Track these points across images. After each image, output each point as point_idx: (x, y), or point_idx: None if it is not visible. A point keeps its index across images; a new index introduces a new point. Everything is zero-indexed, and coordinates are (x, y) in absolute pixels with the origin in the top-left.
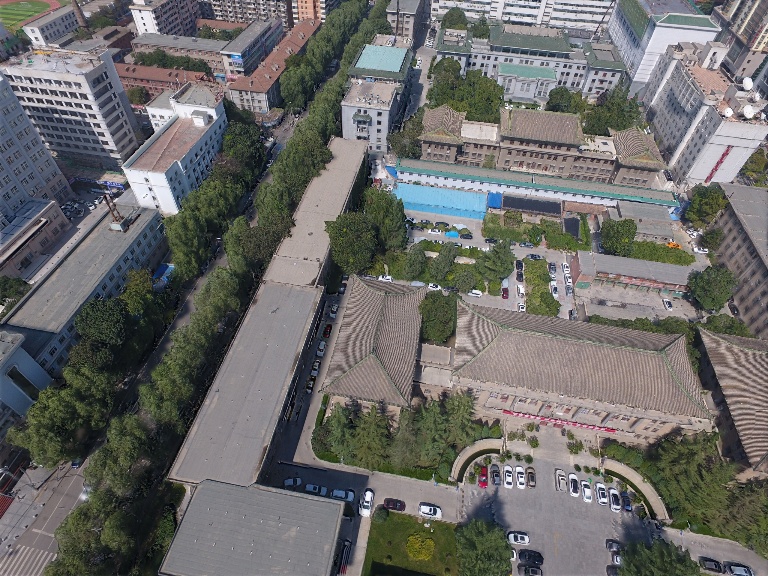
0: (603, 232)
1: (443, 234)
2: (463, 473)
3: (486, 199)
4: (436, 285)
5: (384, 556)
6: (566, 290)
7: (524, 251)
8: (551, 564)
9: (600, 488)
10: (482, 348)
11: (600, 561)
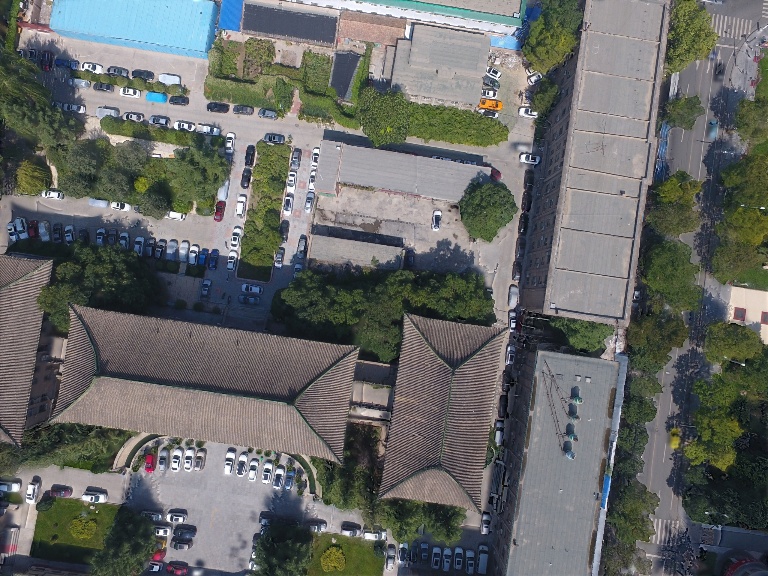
0: (362, 108)
1: (143, 96)
2: (131, 458)
3: (210, 18)
4: (122, 204)
5: (51, 536)
6: (305, 201)
7: (263, 125)
8: (203, 535)
9: (266, 469)
10: (83, 390)
11: (250, 530)
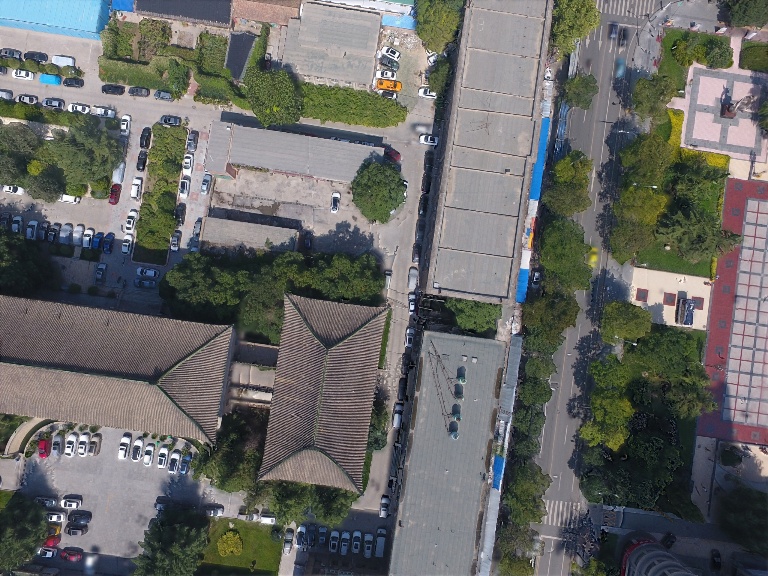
0: None
1: (37, 78)
2: (25, 444)
3: None
4: (14, 187)
5: None
6: None
7: (160, 107)
8: (99, 521)
9: (161, 454)
10: None
11: (146, 515)
